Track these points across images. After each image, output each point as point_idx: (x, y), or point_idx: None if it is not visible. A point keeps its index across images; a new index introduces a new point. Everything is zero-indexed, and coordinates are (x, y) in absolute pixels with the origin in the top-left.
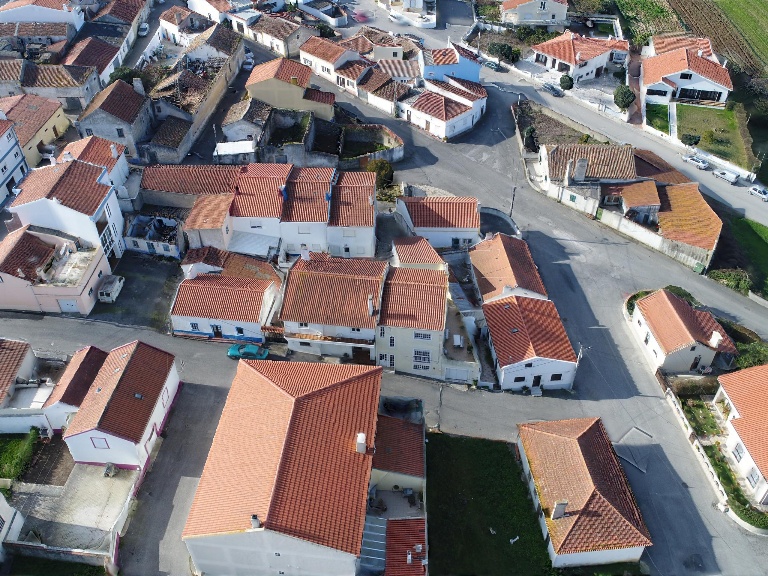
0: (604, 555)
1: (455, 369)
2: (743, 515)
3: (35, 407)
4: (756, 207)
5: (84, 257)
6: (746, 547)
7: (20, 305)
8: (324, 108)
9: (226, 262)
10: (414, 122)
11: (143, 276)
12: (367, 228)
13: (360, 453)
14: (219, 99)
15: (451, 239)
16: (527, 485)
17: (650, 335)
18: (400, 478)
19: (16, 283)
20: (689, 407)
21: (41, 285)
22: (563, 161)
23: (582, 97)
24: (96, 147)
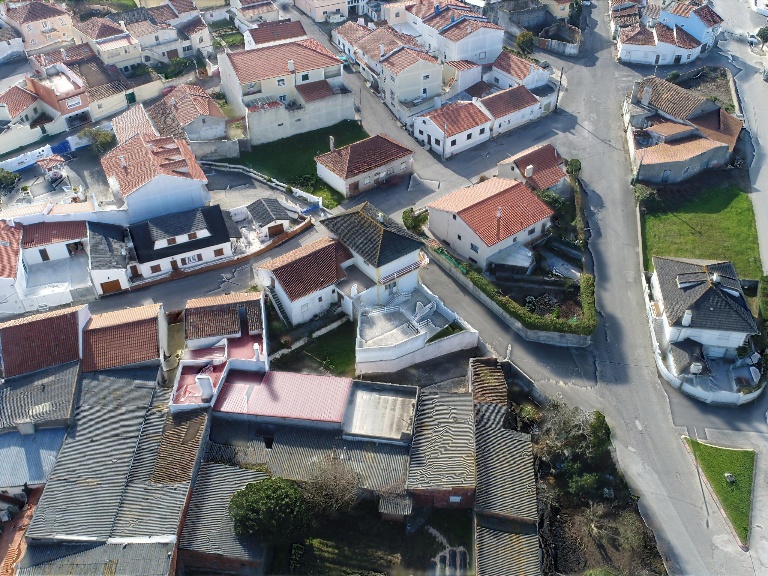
0: None
1: (401, 111)
2: None
3: None
4: None
5: None
6: None
7: None
8: (554, 4)
9: None
10: None
11: None
12: (453, 43)
13: (289, 69)
14: None
15: (509, 85)
16: None
17: None
18: None
19: None
20: None
21: None
22: None
23: None
24: None
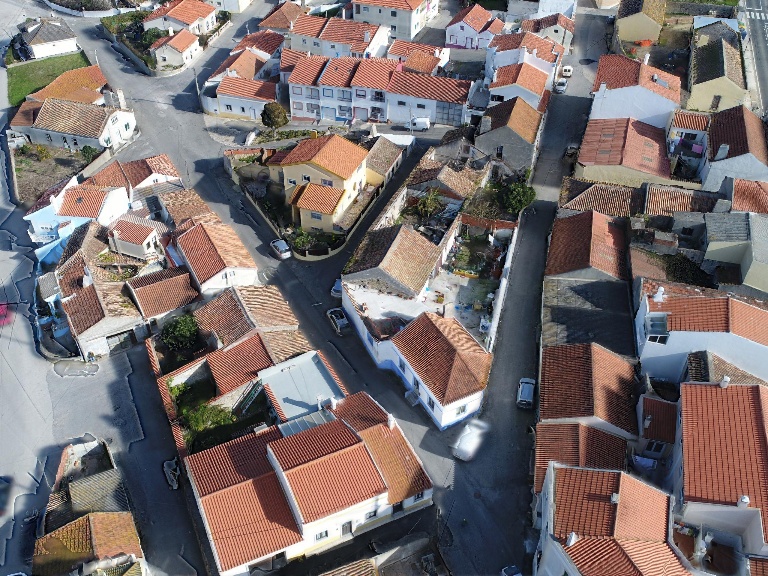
0: None
1: None
2: None
3: (509, 26)
4: None
5: None
6: None
7: None
8: None
9: None
10: None
11: None
12: None
13: None
14: None
15: None
16: None
17: None
18: None
19: None
20: None
21: None
22: None
23: None
24: None
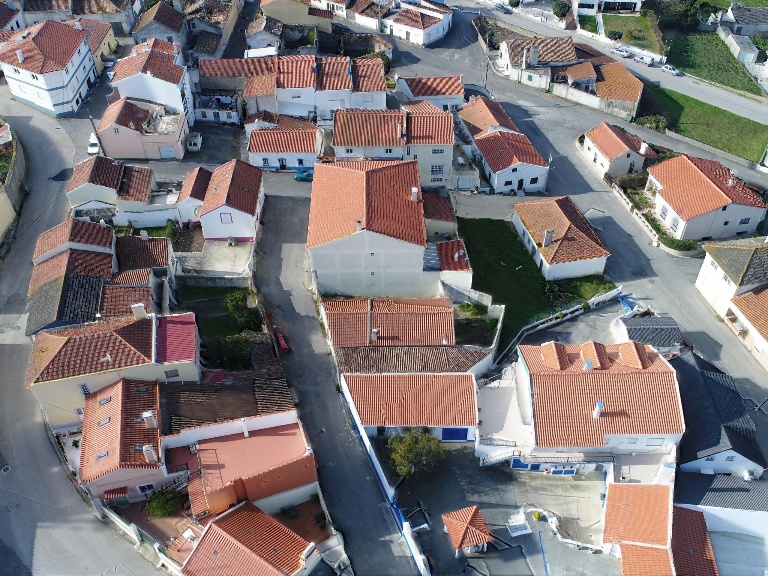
0: (580, 268)
1: (462, 178)
2: (669, 242)
3: None
4: (668, 80)
5: (172, 118)
6: (673, 263)
7: (129, 154)
8: (326, 22)
9: (279, 121)
10: (396, 35)
11: (215, 136)
12: (382, 92)
13: (414, 201)
14: (234, 22)
15: (442, 106)
16: (522, 242)
17: (598, 152)
18: (440, 224)
19: (129, 133)
20: (629, 194)
21: (148, 134)
22: (520, 51)
23: (527, 14)
24: (160, 46)
